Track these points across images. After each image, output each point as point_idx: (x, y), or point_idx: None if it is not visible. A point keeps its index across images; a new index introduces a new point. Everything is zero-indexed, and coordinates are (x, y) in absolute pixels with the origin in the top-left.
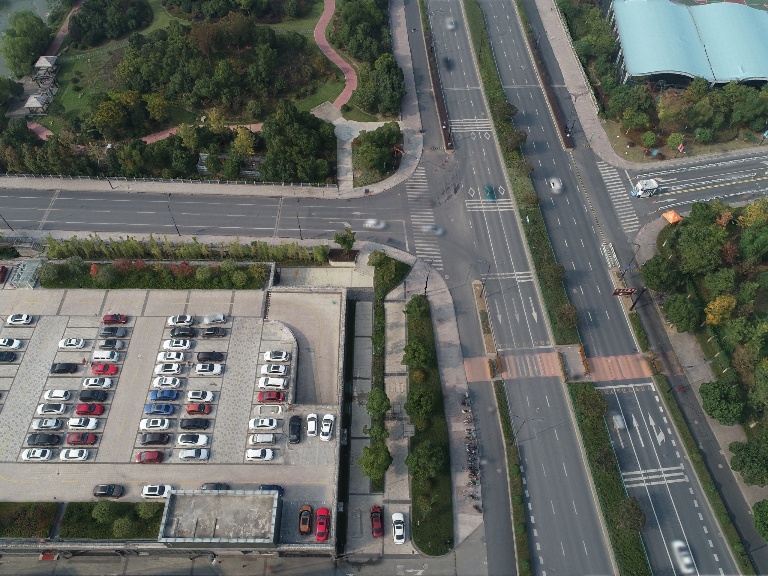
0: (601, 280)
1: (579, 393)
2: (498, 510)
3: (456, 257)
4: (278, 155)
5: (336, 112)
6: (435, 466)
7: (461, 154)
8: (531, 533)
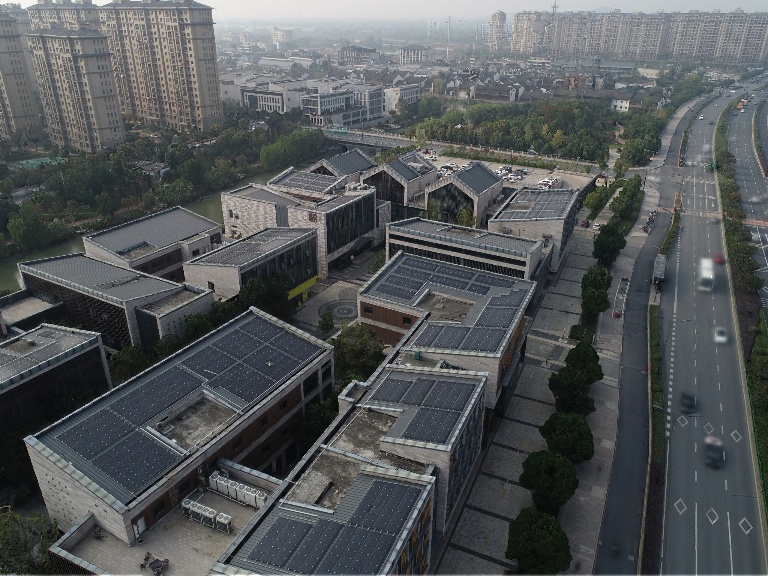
0: (767, 206)
1: (730, 221)
2: (659, 235)
3: None
4: (575, 144)
5: (613, 151)
6: (626, 203)
7: (688, 169)
8: (676, 242)
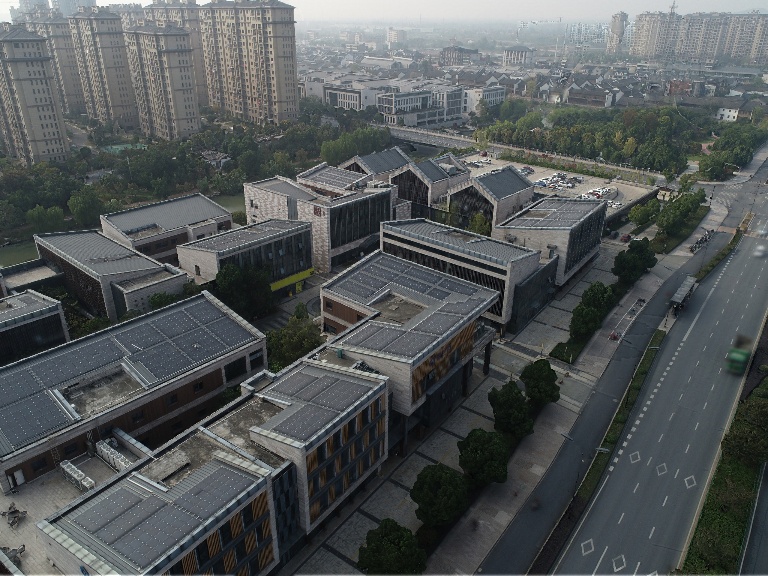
0: None
1: None
2: (706, 256)
3: (742, 206)
4: (647, 153)
5: (694, 163)
6: (674, 219)
7: None
8: (723, 265)
